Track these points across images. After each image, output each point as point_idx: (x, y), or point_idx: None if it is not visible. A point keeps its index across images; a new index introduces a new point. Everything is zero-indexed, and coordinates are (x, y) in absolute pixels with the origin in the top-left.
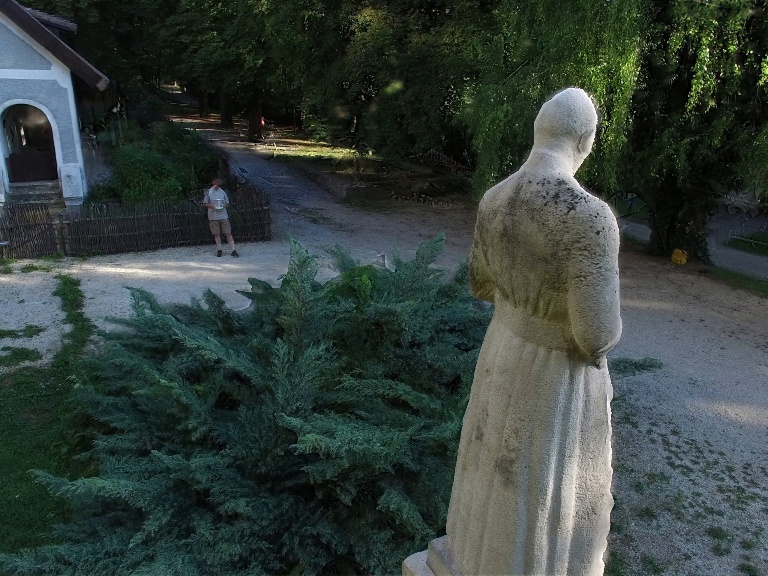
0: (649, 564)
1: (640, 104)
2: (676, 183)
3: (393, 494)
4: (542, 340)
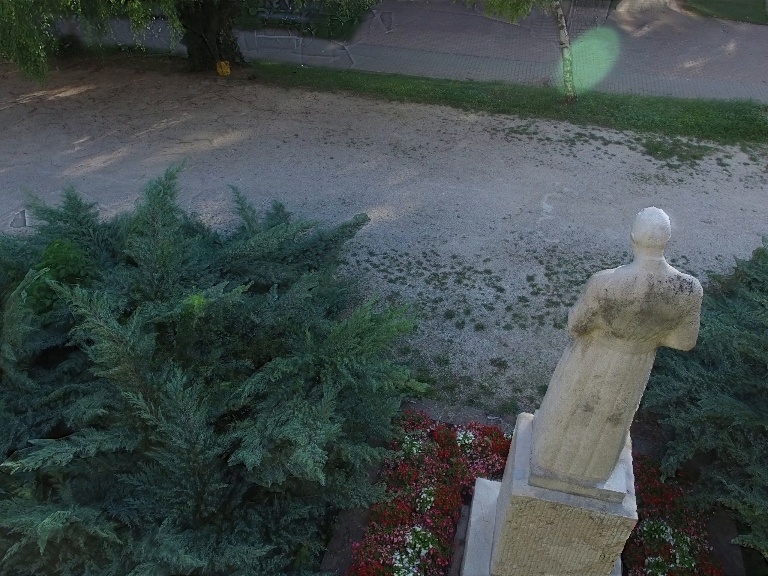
0: (441, 361)
1: None
2: (213, 2)
3: (347, 448)
4: (645, 351)
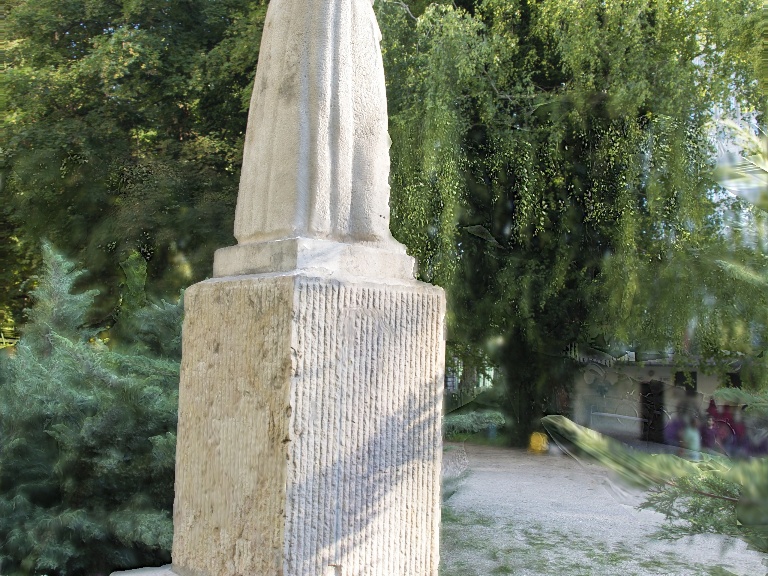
0: None
1: (463, 225)
2: (519, 336)
3: None
4: None
